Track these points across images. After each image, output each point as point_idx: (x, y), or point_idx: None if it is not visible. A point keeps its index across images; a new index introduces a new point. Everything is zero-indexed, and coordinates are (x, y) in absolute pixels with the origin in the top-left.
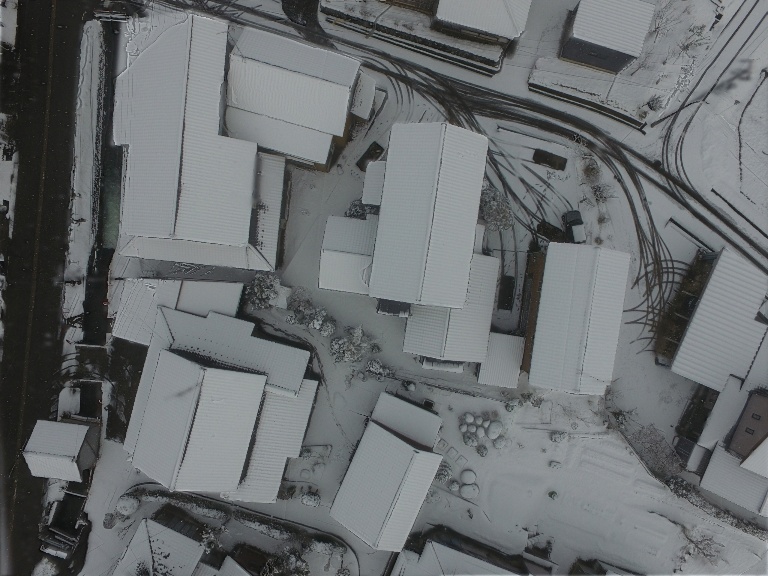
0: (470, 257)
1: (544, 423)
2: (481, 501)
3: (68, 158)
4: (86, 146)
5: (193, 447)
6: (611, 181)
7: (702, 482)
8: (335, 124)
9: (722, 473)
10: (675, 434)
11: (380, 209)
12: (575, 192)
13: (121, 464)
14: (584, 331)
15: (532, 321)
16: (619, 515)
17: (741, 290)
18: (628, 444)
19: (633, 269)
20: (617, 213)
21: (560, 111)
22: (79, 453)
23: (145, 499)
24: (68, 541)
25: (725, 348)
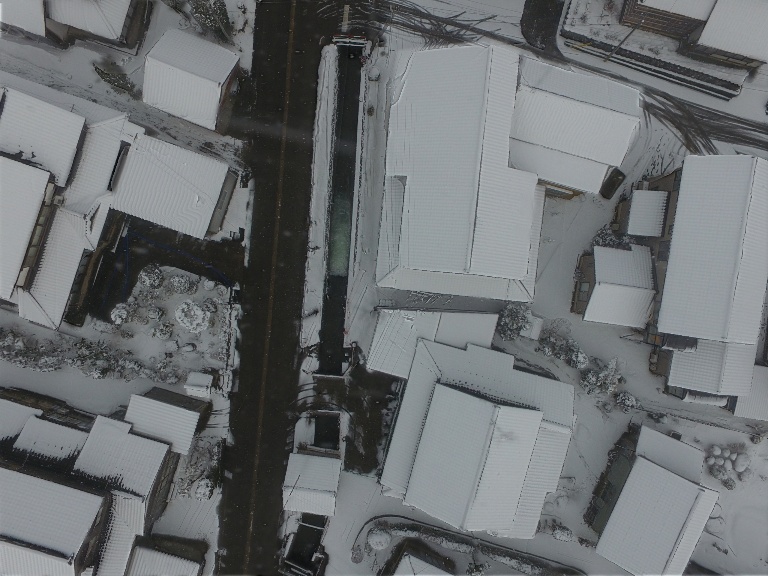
0: (764, 292)
1: None
2: (725, 535)
3: (305, 185)
4: (322, 173)
5: (483, 486)
6: None
7: None
8: (614, 154)
9: None
10: None
11: (671, 242)
12: None
13: (359, 496)
14: None
15: None
16: None
17: None
18: None
19: None
20: None
21: None
22: None
23: (395, 533)
24: (304, 574)
25: None
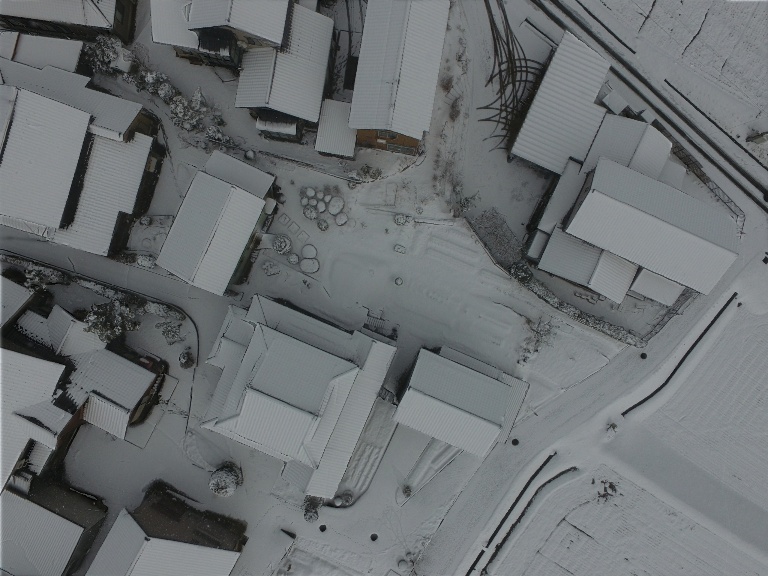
0: None
1: (388, 204)
2: (322, 277)
3: None
4: None
5: (7, 168)
6: None
7: (540, 263)
8: None
9: (558, 252)
10: (526, 232)
11: None
12: None
13: None
14: (396, 66)
15: None
16: (464, 304)
17: (581, 73)
18: (473, 232)
19: (487, 67)
20: (472, 10)
21: None
22: None
23: None
24: None
25: (565, 131)
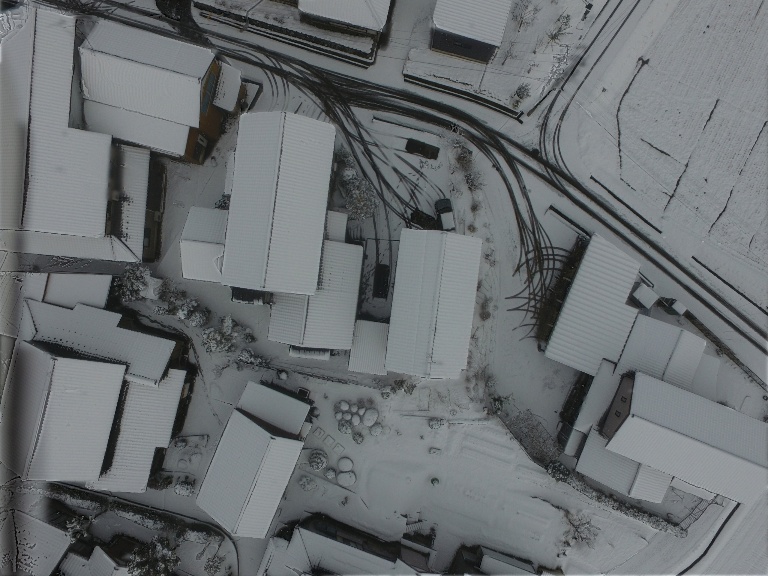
0: (320, 244)
1: (422, 410)
2: (359, 488)
3: None
4: None
5: (46, 436)
6: (489, 170)
7: (577, 466)
8: (190, 115)
9: (596, 456)
10: (559, 419)
11: (230, 198)
12: (447, 180)
13: None
14: (432, 315)
15: None
16: (501, 501)
17: (611, 275)
18: (508, 430)
19: (514, 256)
20: (496, 201)
21: (436, 101)
22: None
23: (19, 491)
24: None
25: (597, 332)
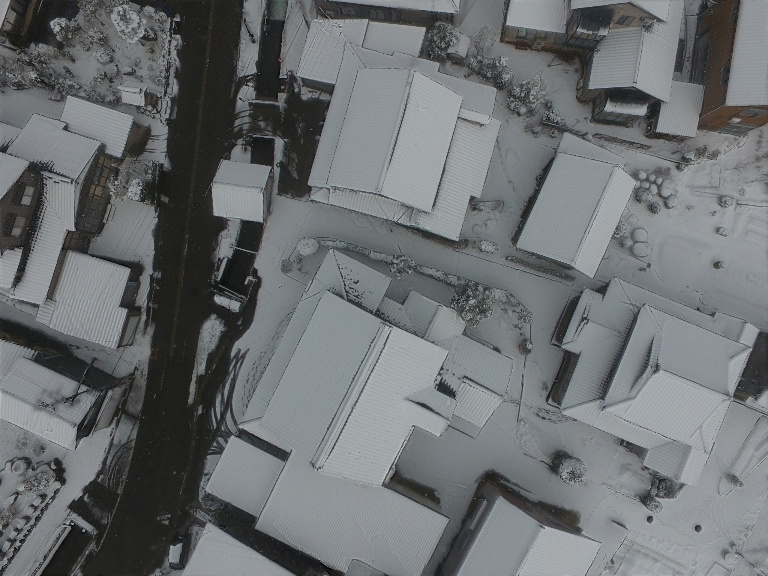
0: None
1: (713, 186)
2: (652, 261)
3: None
4: None
5: (399, 151)
6: None
7: None
8: None
9: None
10: None
11: None
12: None
13: (292, 219)
14: None
15: (718, 60)
16: None
17: None
18: None
19: None
20: None
21: None
22: None
23: (323, 243)
24: (237, 297)
25: None
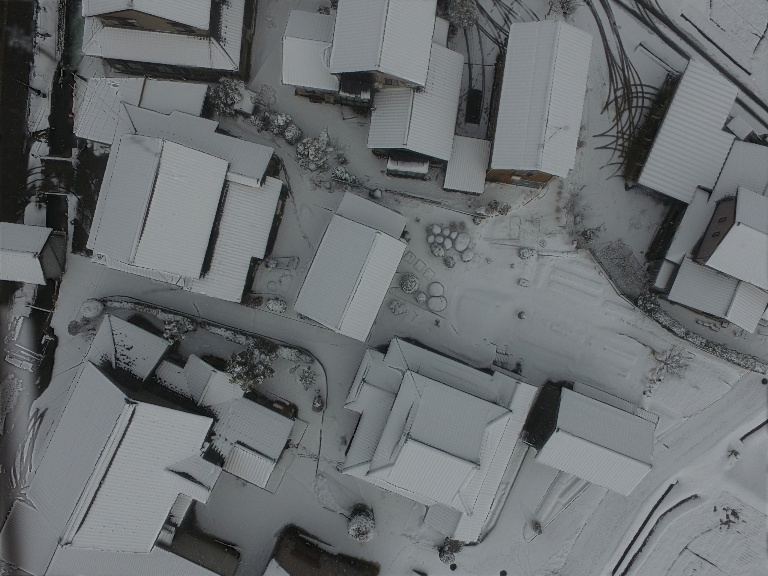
0: (431, 33)
1: (512, 238)
2: (449, 315)
3: None
4: None
5: (153, 222)
6: None
7: (670, 294)
8: None
9: (690, 283)
10: (645, 260)
11: None
12: (542, 5)
13: (87, 278)
14: (545, 105)
15: None
16: (588, 336)
17: (708, 100)
18: (597, 263)
19: (603, 94)
20: None
21: None
22: (42, 252)
23: (110, 304)
24: (34, 356)
25: (692, 159)
